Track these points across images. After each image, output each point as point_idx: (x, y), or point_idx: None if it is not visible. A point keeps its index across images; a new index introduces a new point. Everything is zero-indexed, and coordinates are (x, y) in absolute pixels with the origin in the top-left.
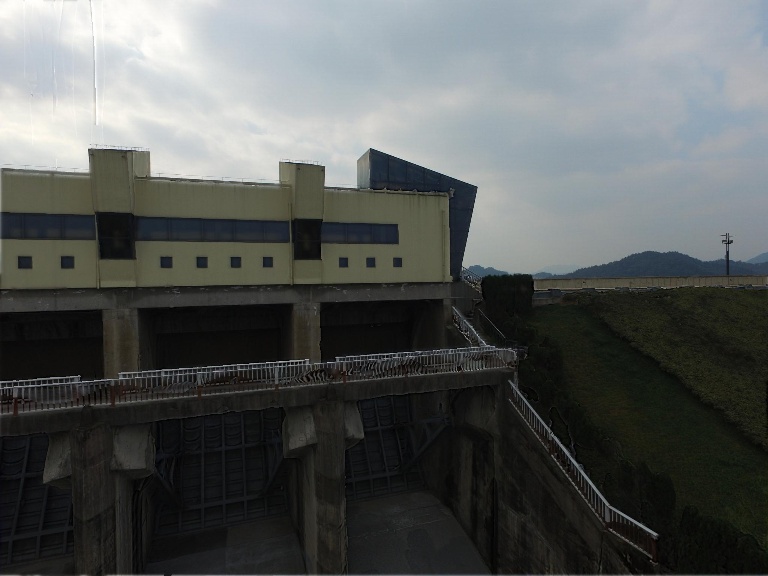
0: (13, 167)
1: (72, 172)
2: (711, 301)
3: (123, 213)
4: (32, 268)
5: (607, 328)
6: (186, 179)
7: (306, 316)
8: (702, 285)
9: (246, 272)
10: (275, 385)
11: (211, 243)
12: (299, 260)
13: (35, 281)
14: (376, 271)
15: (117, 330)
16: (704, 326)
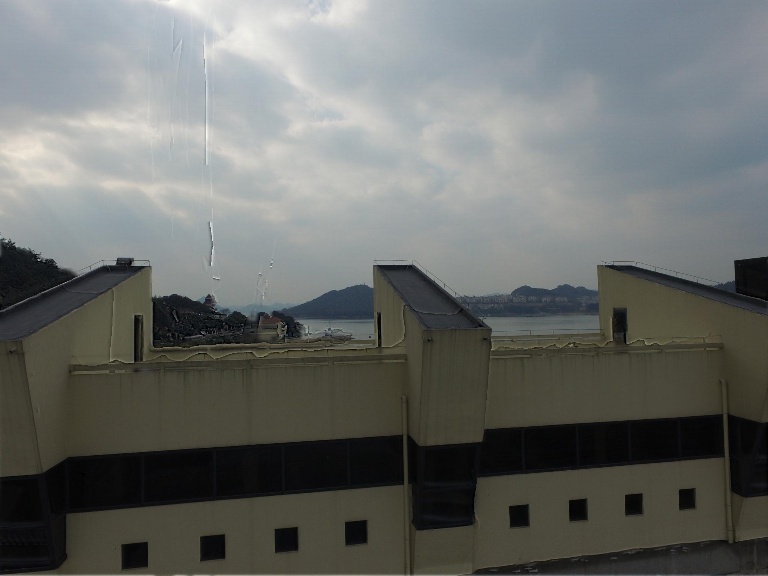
0: (269, 355)
1: (364, 355)
2: None
3: (468, 443)
4: (297, 550)
5: None
6: (550, 349)
7: None
8: None
9: (651, 522)
10: None
11: (592, 470)
12: (751, 497)
13: (302, 575)
14: None
15: None
16: None
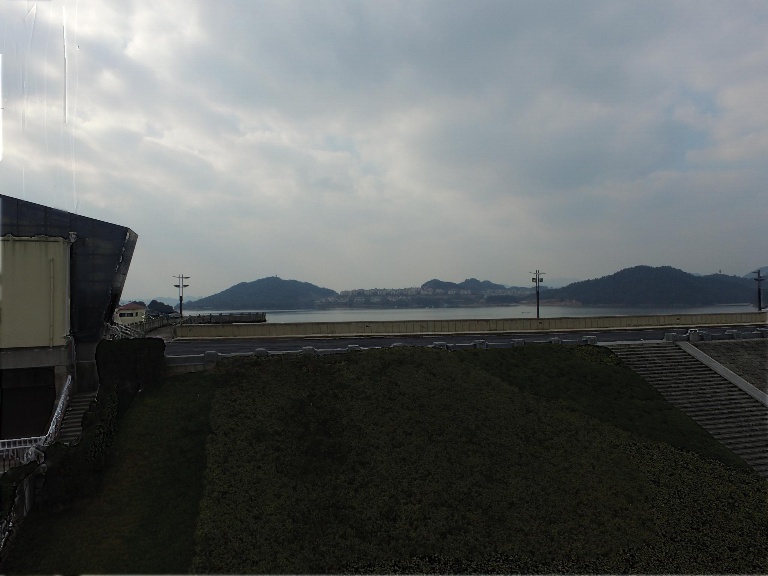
0: None
1: None
2: (394, 368)
3: None
4: None
5: None
6: None
7: None
8: (506, 329)
9: None
10: None
11: None
12: None
13: None
14: None
15: None
16: (337, 407)
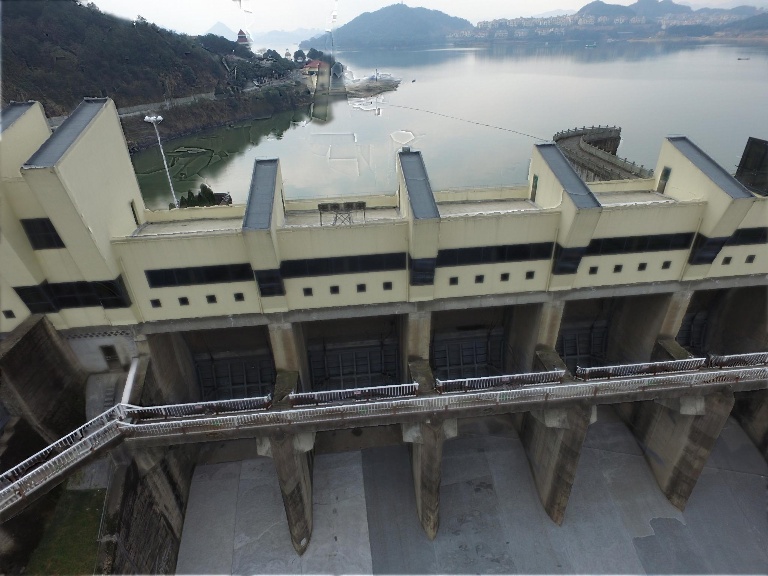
0: (506, 213)
1: (544, 212)
2: None
3: (582, 247)
4: (508, 280)
5: None
6: (624, 207)
7: (680, 300)
8: None
9: (647, 273)
10: (690, 384)
11: (628, 254)
12: (695, 265)
13: (509, 288)
14: (752, 265)
15: (550, 314)
16: None
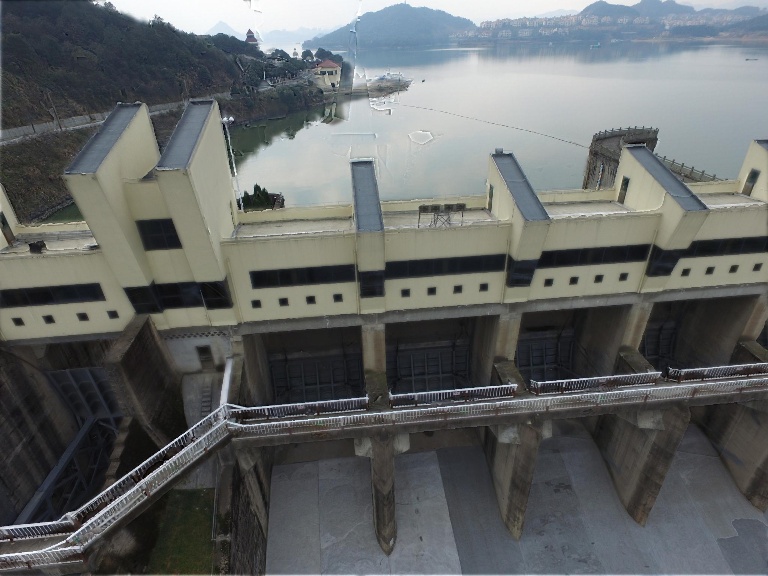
0: (608, 215)
1: (645, 214)
2: None
3: (682, 249)
4: (602, 282)
5: None
6: (723, 209)
7: (766, 302)
8: None
9: (738, 275)
10: None
11: (722, 256)
12: None
13: (601, 290)
14: None
15: (637, 316)
16: None
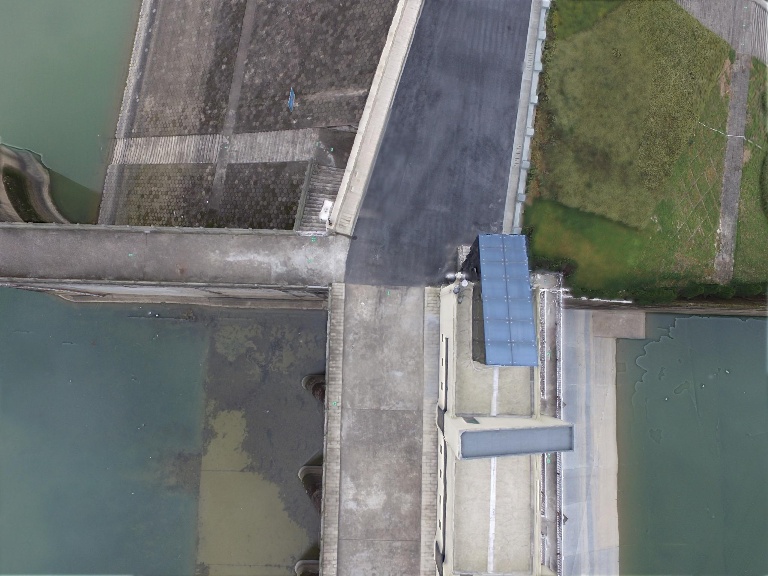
0: None
1: None
2: (565, 90)
3: None
4: None
5: (563, 205)
6: None
7: None
8: None
9: None
10: None
11: None
12: None
13: None
14: None
15: None
16: (583, 141)
